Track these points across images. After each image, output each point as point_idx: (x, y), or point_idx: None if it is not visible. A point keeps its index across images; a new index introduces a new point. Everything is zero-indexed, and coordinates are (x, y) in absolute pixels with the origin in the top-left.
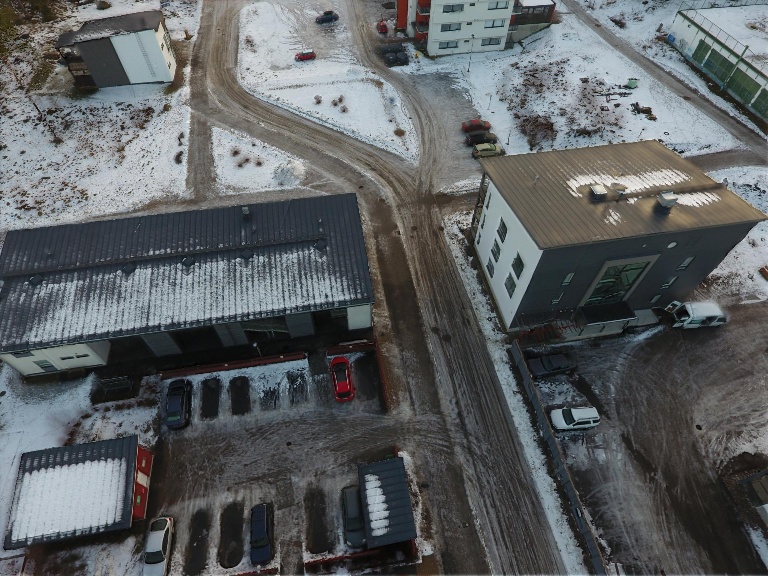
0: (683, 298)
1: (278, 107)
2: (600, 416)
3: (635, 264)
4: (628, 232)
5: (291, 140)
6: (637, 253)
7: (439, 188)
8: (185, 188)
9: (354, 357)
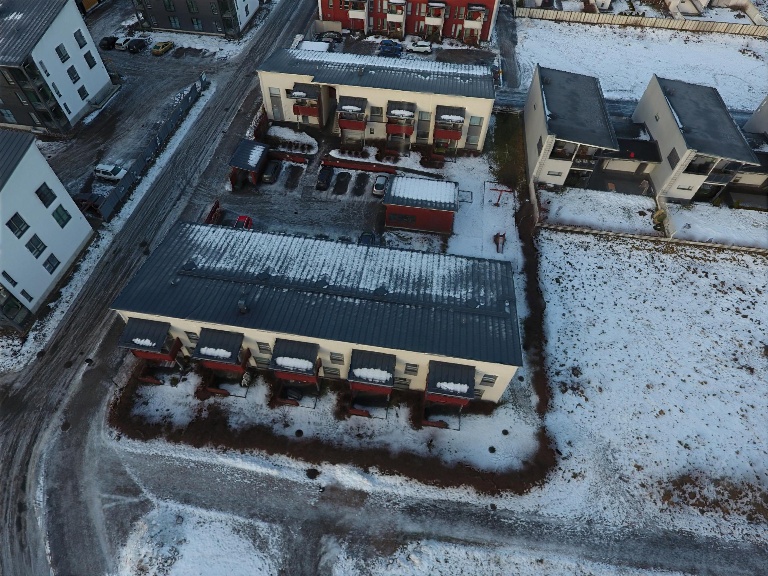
0: None
1: None
2: None
3: None
4: None
5: None
6: None
7: None
8: (333, 571)
9: None
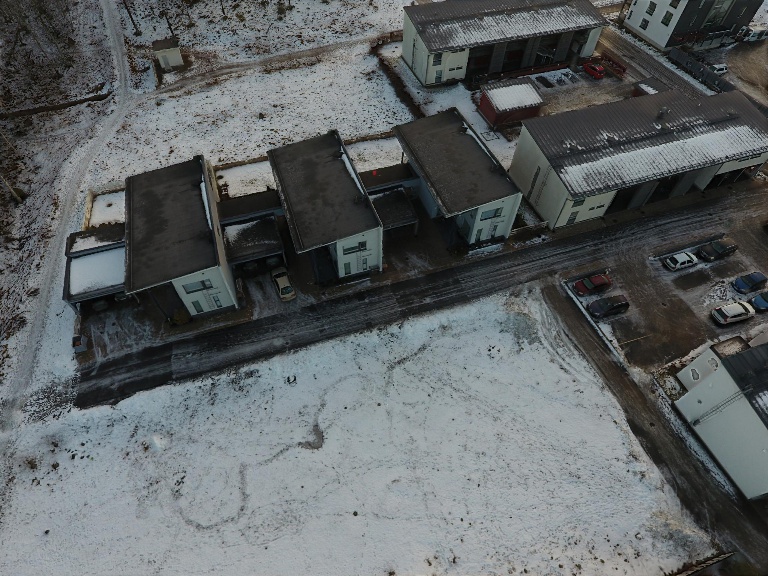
0: (747, 24)
1: None
2: None
3: None
4: None
5: None
6: None
7: None
8: None
9: None
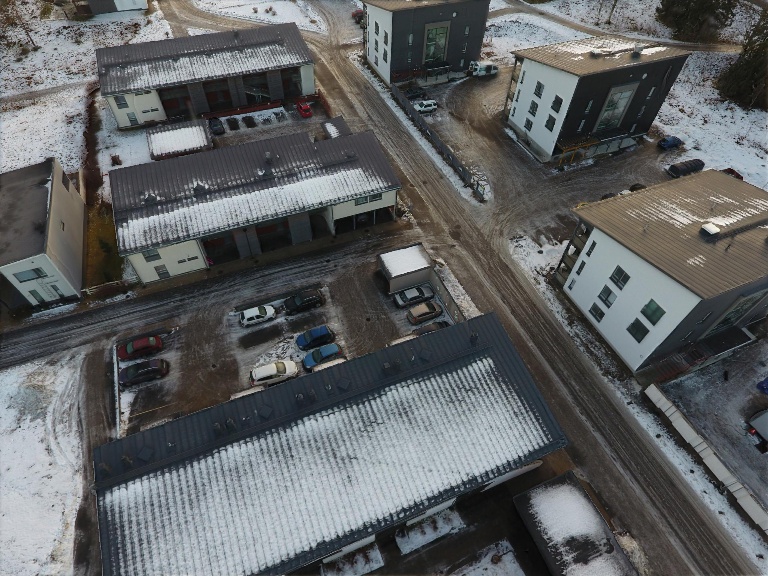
0: (475, 59)
1: (229, 16)
2: (438, 108)
3: (441, 28)
4: (430, 4)
5: None
6: (439, 20)
7: (343, 42)
8: None
9: (309, 104)
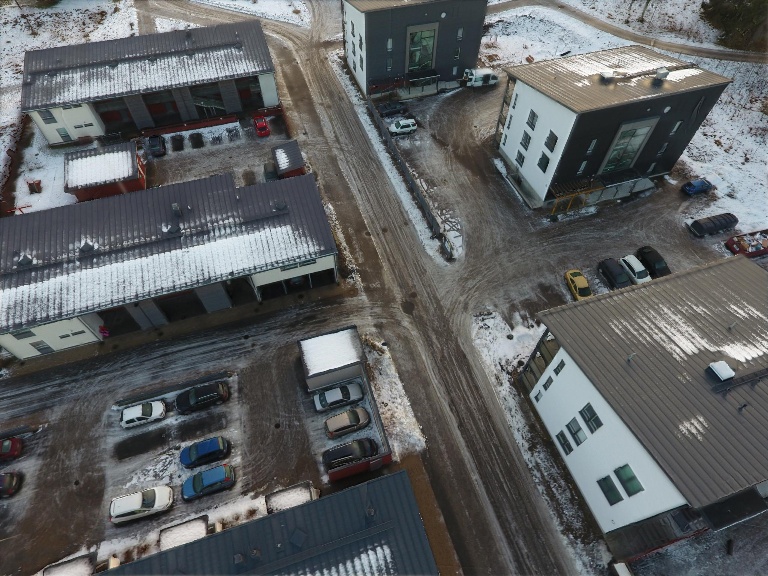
0: (470, 67)
1: (204, 4)
2: (419, 128)
3: (427, 32)
4: (412, 3)
5: (216, 22)
6: (424, 22)
7: (325, 39)
8: None
9: (269, 118)
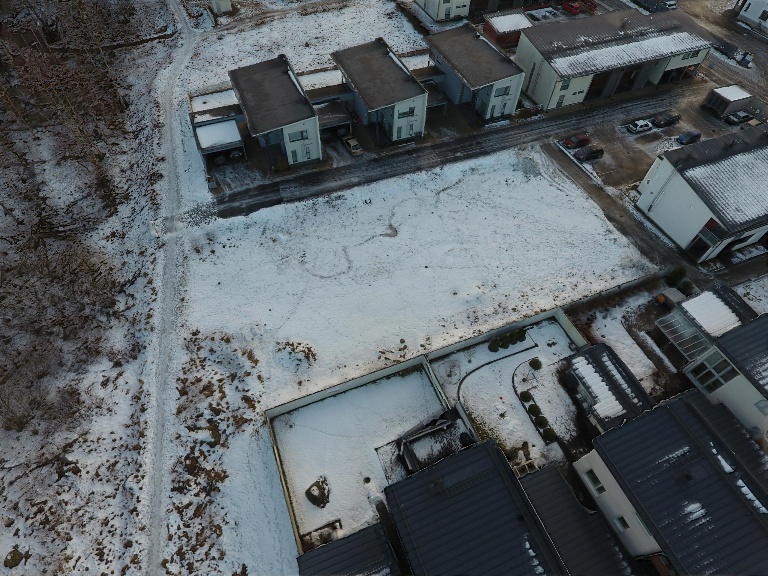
0: None
1: None
2: None
3: None
4: None
5: None
6: None
7: None
8: None
9: None
